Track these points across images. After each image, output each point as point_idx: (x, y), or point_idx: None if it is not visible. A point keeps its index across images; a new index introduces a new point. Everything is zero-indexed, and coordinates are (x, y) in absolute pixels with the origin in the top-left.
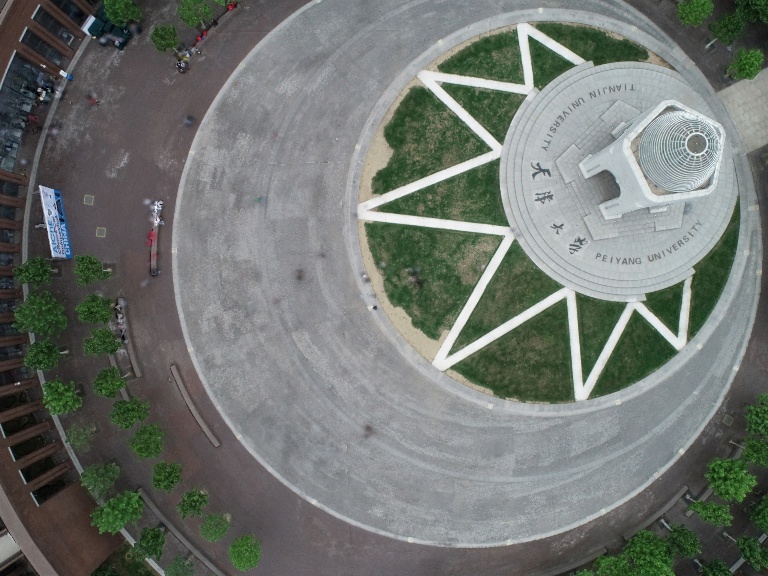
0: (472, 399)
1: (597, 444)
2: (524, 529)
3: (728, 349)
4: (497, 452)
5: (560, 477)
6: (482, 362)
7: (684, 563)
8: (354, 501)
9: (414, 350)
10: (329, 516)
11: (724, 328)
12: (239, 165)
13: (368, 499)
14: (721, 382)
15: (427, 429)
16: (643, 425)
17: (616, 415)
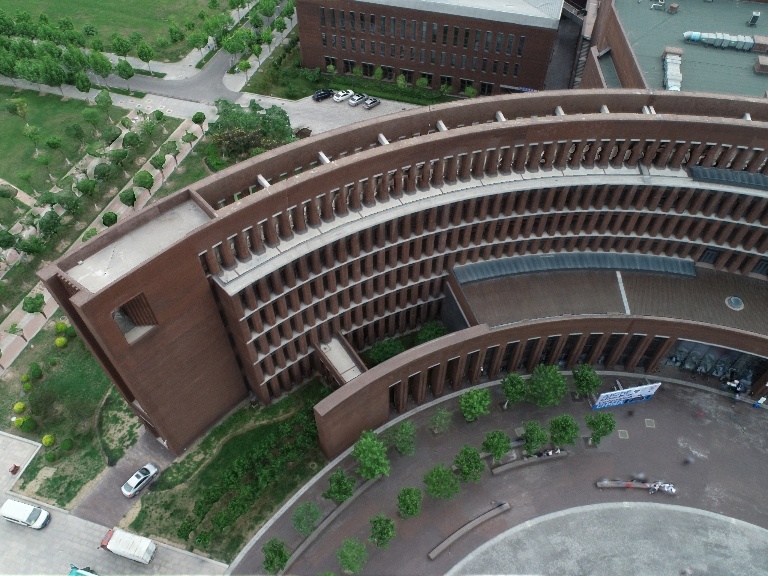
0: None
1: None
2: None
3: None
4: None
5: None
6: None
7: None
8: None
9: None
10: None
11: None
12: (741, 574)
13: None
14: None
15: None
16: None
17: None
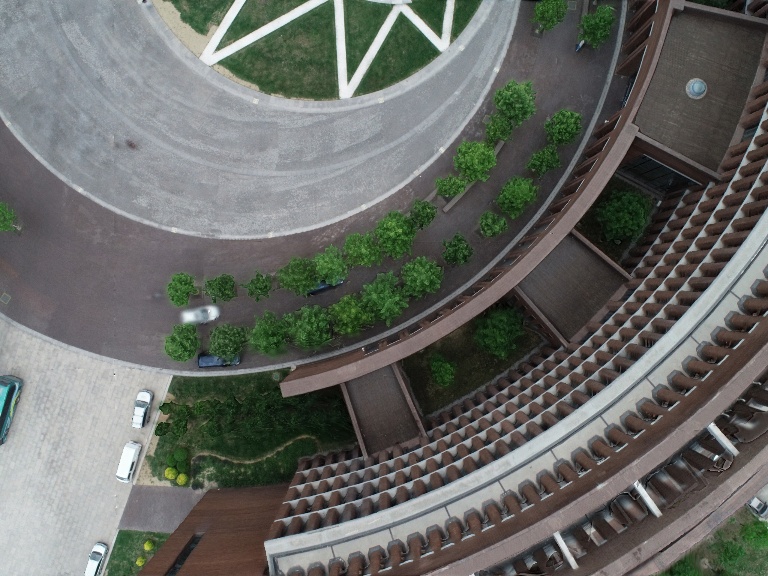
0: (238, 94)
1: (359, 141)
2: (286, 222)
3: (489, 51)
4: (261, 146)
5: (322, 172)
6: (249, 58)
7: (442, 259)
8: (120, 190)
9: (182, 44)
10: (95, 204)
11: (486, 30)
12: None
13: (133, 189)
14: (482, 83)
15: (193, 122)
16: (405, 123)
17: (379, 113)
